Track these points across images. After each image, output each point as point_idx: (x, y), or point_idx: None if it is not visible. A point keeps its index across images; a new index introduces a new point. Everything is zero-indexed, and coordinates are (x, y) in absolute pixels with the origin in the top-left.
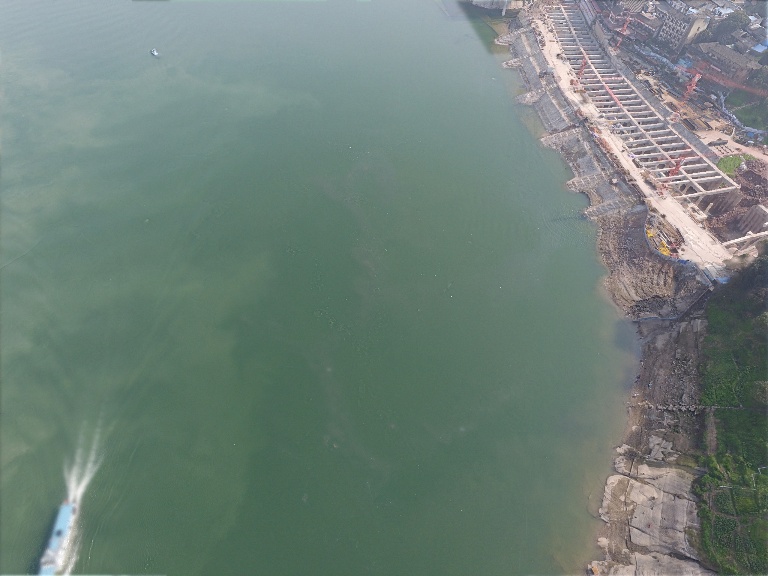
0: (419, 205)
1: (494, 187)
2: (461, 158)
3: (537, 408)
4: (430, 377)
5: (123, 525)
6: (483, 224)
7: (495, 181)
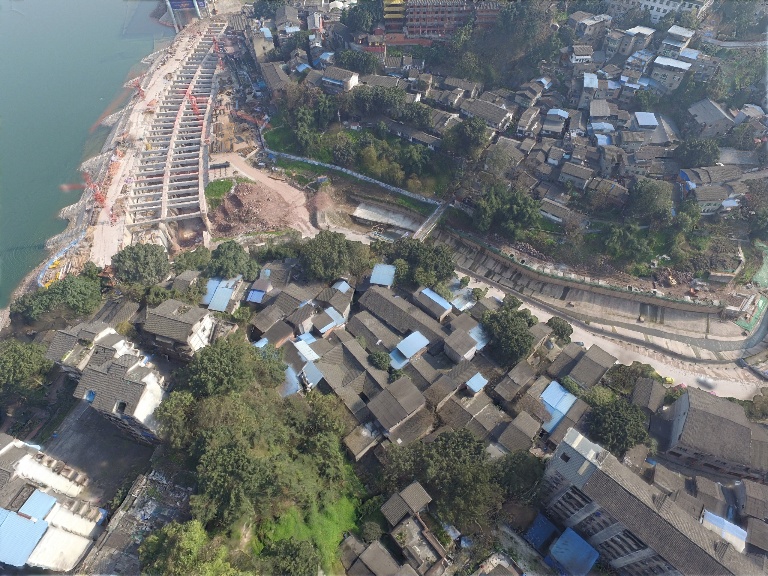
0: None
1: None
2: None
3: None
4: None
5: None
6: None
7: None
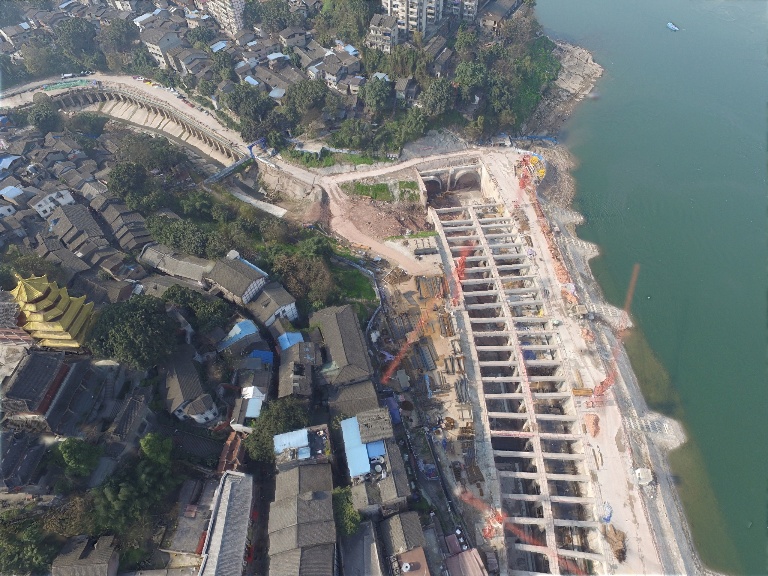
0: (761, 237)
1: (682, 258)
2: (739, 297)
3: None
4: (693, 126)
5: None
6: (686, 212)
7: (683, 266)
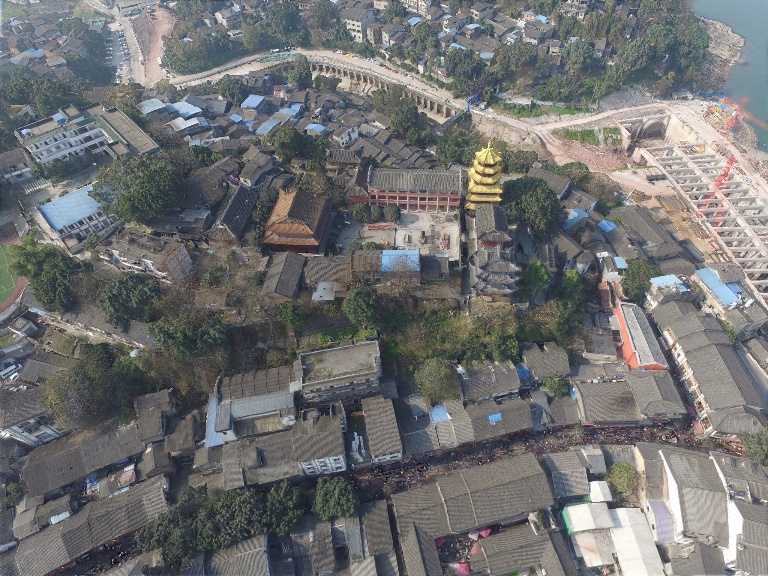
0: None
1: None
2: None
3: None
4: None
5: None
6: None
7: None
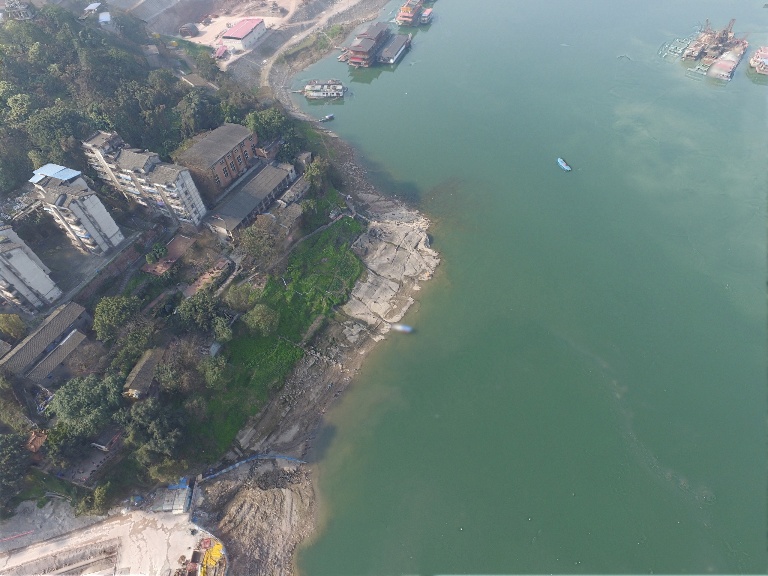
0: None
1: None
2: None
3: (442, 374)
4: (548, 405)
5: (765, 302)
6: None
7: None
